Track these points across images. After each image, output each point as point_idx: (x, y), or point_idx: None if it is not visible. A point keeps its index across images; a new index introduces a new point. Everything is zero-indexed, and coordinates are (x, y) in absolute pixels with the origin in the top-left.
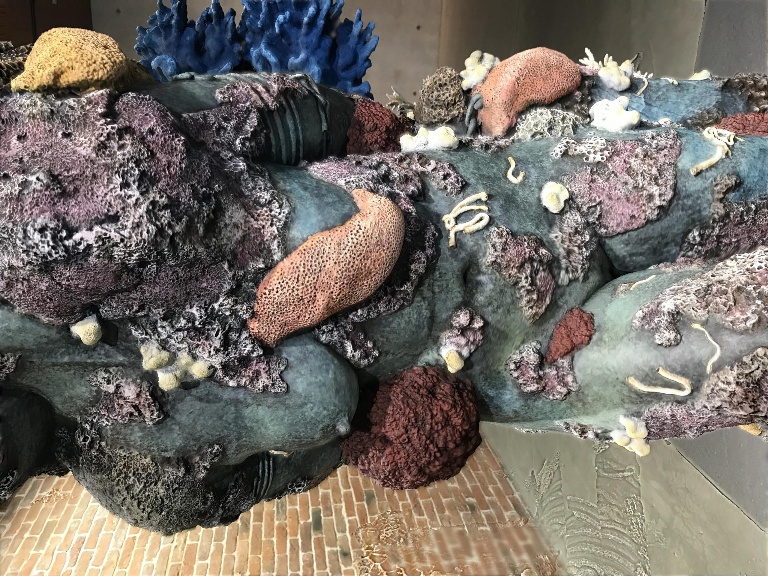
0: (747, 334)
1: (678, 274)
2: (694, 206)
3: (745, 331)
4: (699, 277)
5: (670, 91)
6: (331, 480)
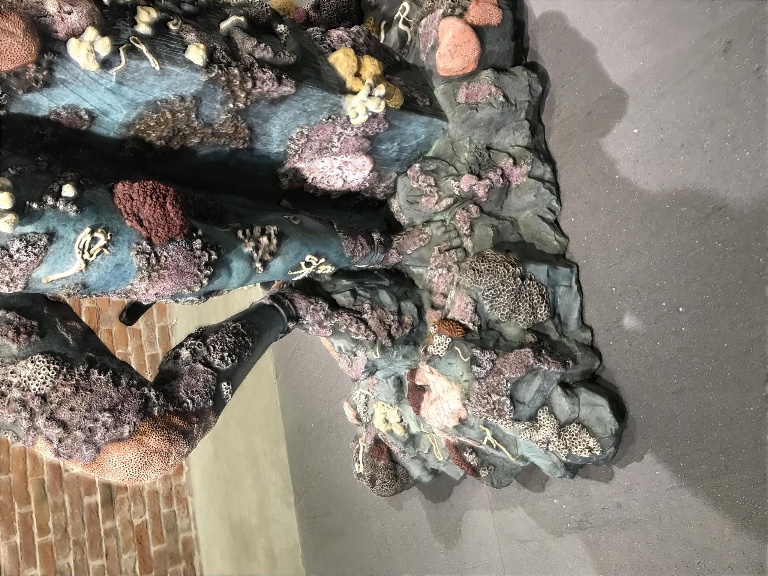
0: (7, 422)
1: (1, 347)
2: (44, 292)
3: (6, 421)
4: (5, 367)
5: (148, 74)
6: None
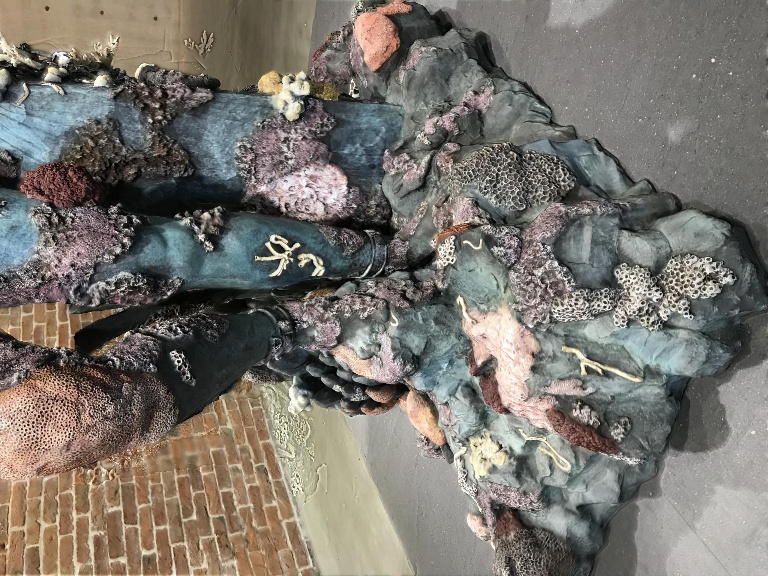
0: None
1: None
2: None
3: None
4: None
5: (56, 101)
6: (48, 313)
